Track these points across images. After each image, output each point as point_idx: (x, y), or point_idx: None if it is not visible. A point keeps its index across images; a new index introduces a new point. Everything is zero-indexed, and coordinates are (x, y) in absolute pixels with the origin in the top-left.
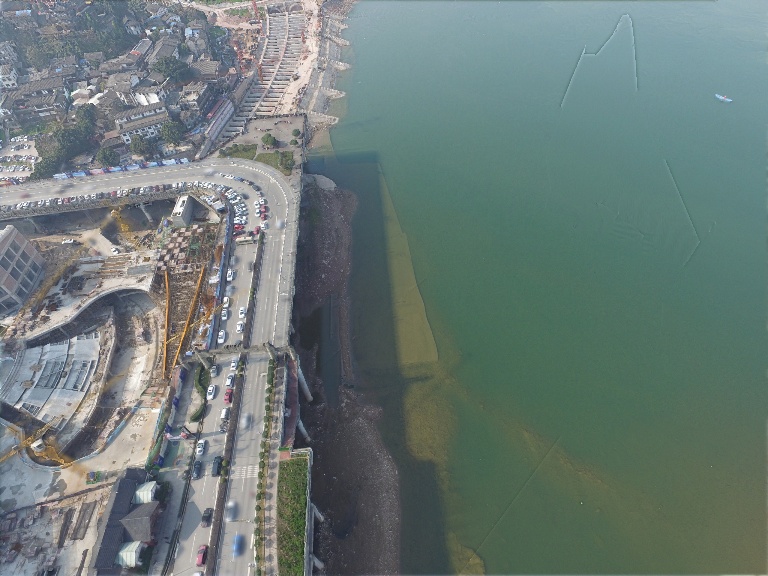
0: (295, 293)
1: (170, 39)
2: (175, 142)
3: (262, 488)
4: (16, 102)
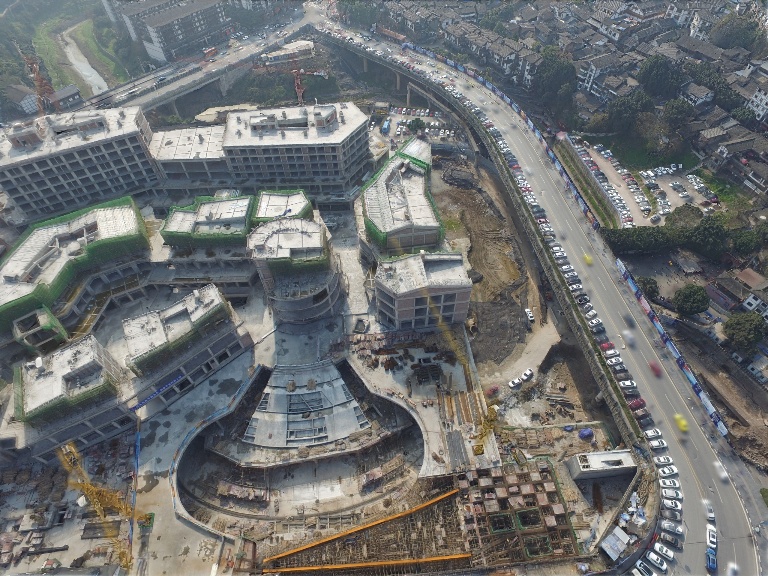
0: None
1: None
2: None
3: None
4: (750, 151)
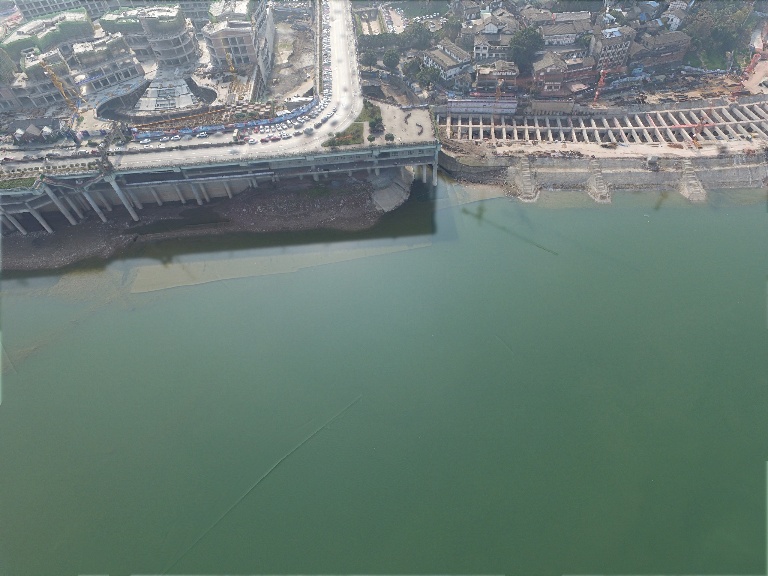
0: (235, 198)
1: (587, 24)
2: (420, 84)
3: (27, 173)
4: None
